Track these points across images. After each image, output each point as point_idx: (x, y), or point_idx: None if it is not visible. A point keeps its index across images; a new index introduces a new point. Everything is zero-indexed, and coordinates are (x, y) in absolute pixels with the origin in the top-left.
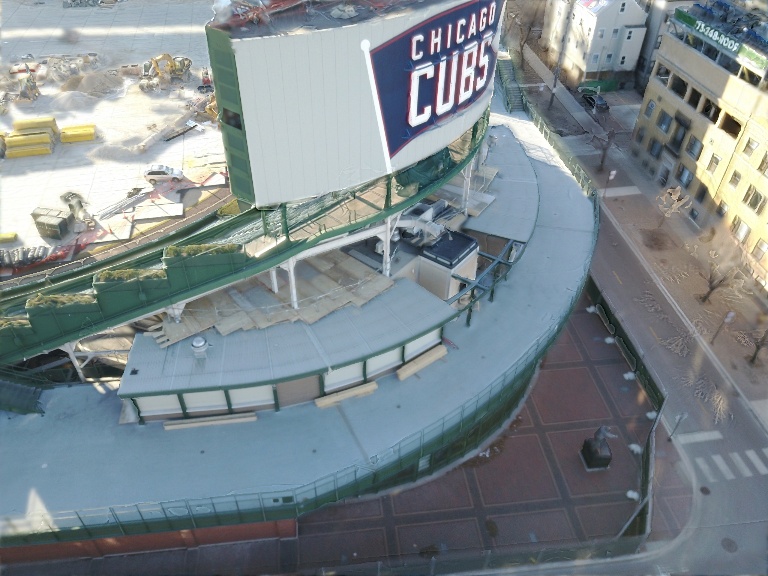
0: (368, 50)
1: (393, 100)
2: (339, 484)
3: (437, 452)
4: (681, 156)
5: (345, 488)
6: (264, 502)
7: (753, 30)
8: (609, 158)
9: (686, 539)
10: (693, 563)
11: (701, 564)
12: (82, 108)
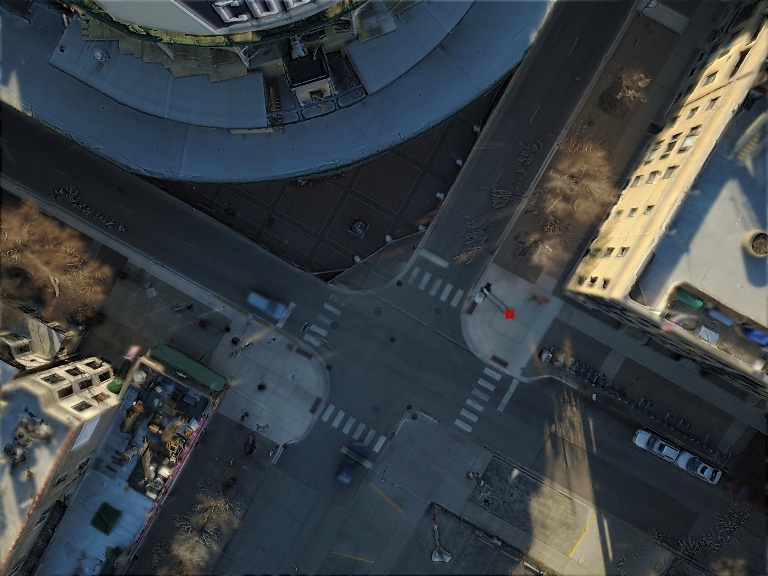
0: None
1: None
2: None
3: None
4: (728, 35)
5: None
6: None
7: None
8: None
9: (360, 294)
10: (350, 305)
11: (353, 308)
12: None
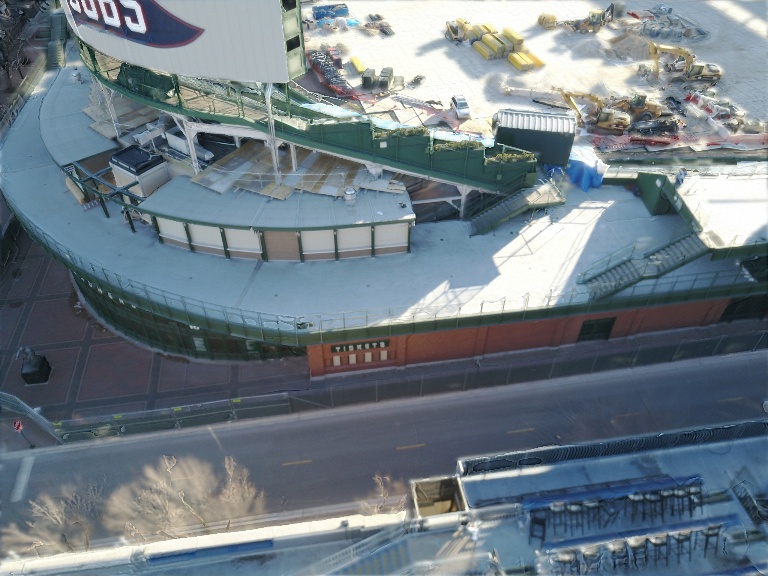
0: None
1: None
2: None
3: None
4: None
5: None
6: None
7: (765, 541)
8: None
9: None
10: None
11: None
12: (580, 54)
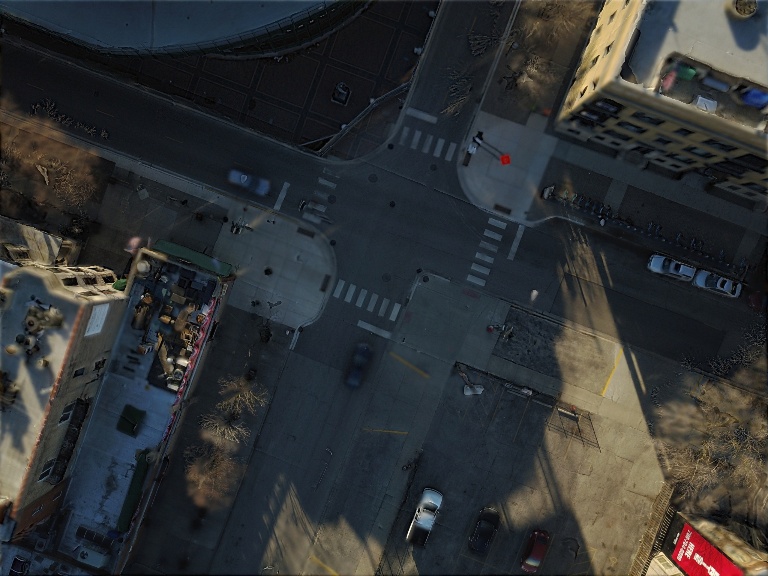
0: None
1: None
2: None
3: None
4: None
5: (133, 56)
6: None
7: None
8: None
9: (353, 164)
10: (345, 176)
11: (348, 178)
12: None
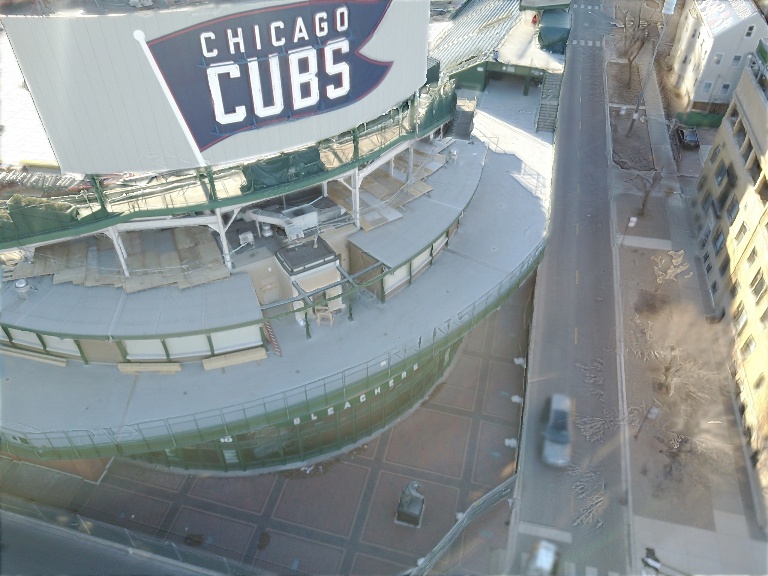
0: (144, 41)
1: (188, 94)
2: (75, 443)
3: (258, 452)
4: (722, 217)
5: (82, 448)
6: (6, 436)
7: None
8: (661, 203)
9: None
10: None
11: None
12: None
